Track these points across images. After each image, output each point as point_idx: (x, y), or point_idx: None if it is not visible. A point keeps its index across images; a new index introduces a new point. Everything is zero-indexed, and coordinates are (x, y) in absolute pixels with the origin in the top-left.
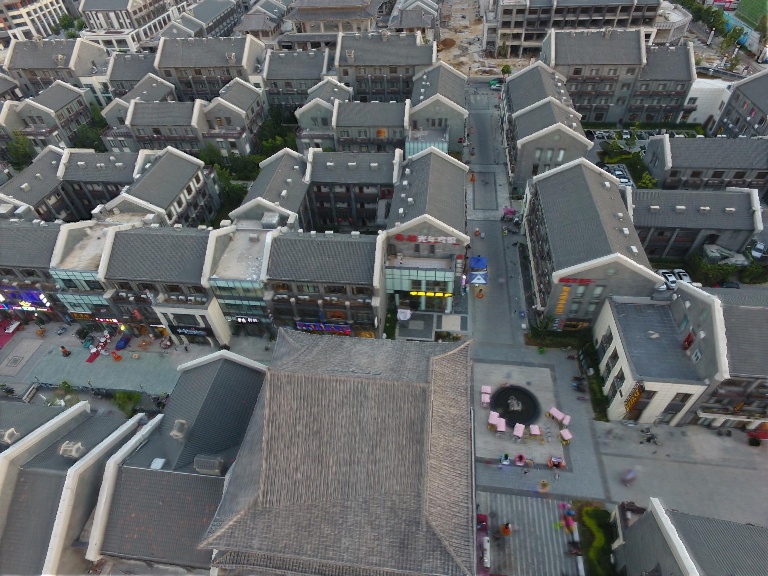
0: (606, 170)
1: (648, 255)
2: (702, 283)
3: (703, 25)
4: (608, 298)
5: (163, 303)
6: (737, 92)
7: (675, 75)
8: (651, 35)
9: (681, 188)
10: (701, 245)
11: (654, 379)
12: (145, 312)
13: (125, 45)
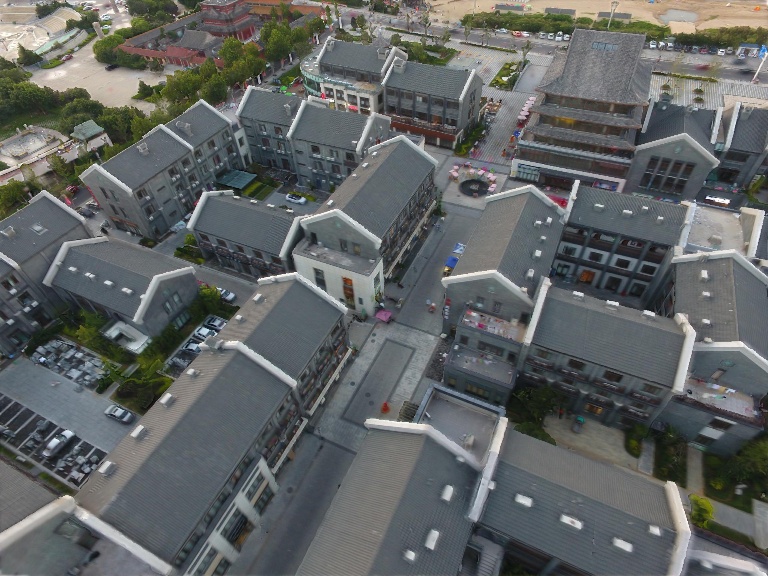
0: None
1: None
2: None
3: None
4: None
5: None
6: None
7: None
8: None
9: None
10: None
11: None
12: None
13: None
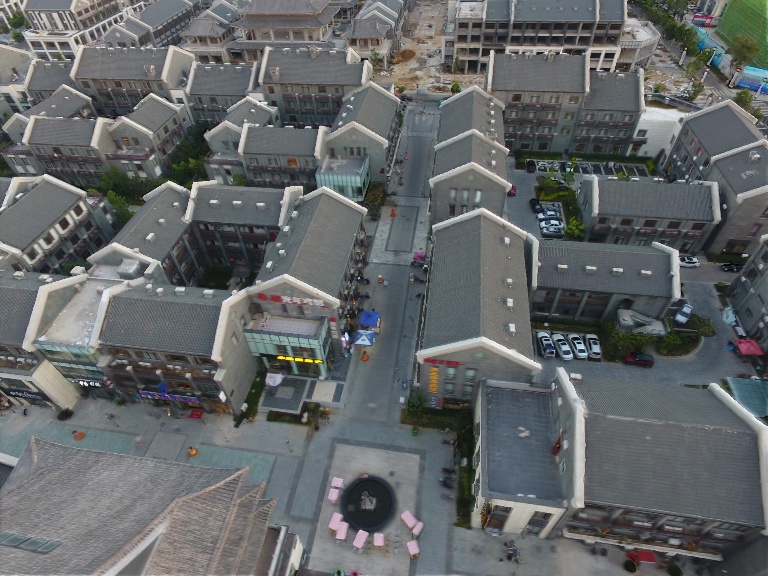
0: (538, 209)
1: (562, 315)
2: (611, 355)
3: (676, 44)
4: (482, 382)
5: None
6: (687, 127)
7: (622, 105)
8: (615, 55)
9: (611, 236)
10: (615, 310)
11: (505, 497)
12: None
13: (68, 48)
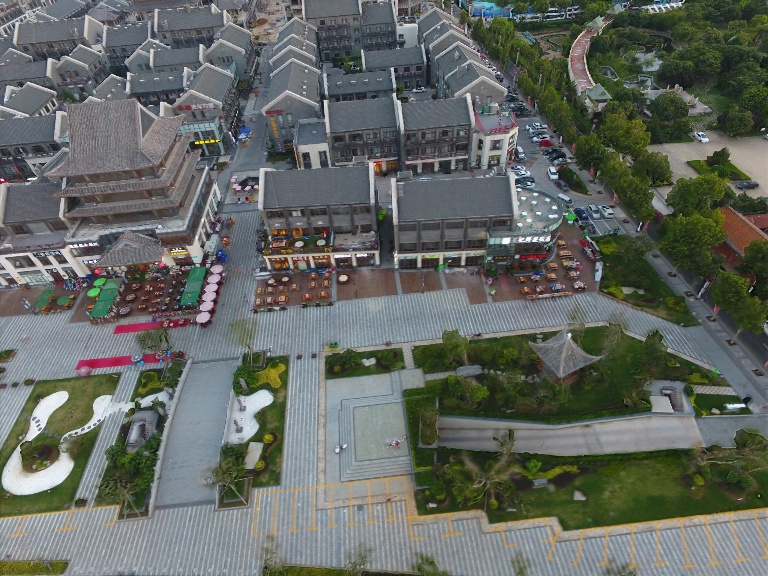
0: None
1: None
2: None
3: None
4: (296, 121)
5: (32, 156)
6: (419, 27)
7: (384, 20)
8: (395, 3)
9: None
10: None
11: (303, 144)
12: (22, 170)
13: None
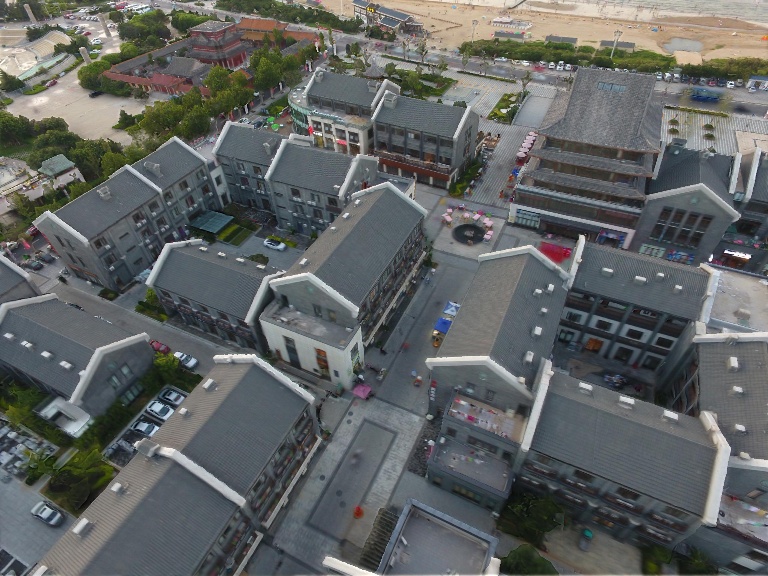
0: None
1: None
2: None
3: None
4: None
5: None
6: None
7: None
8: None
9: None
10: None
11: None
12: None
13: None
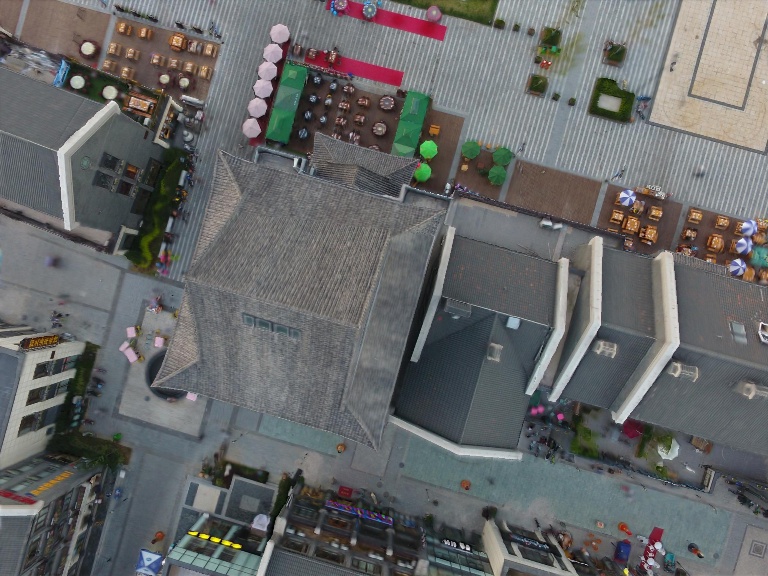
0: None
1: None
2: None
3: None
4: None
5: None
6: None
7: None
8: None
9: None
10: None
11: (5, 351)
12: None
13: None
